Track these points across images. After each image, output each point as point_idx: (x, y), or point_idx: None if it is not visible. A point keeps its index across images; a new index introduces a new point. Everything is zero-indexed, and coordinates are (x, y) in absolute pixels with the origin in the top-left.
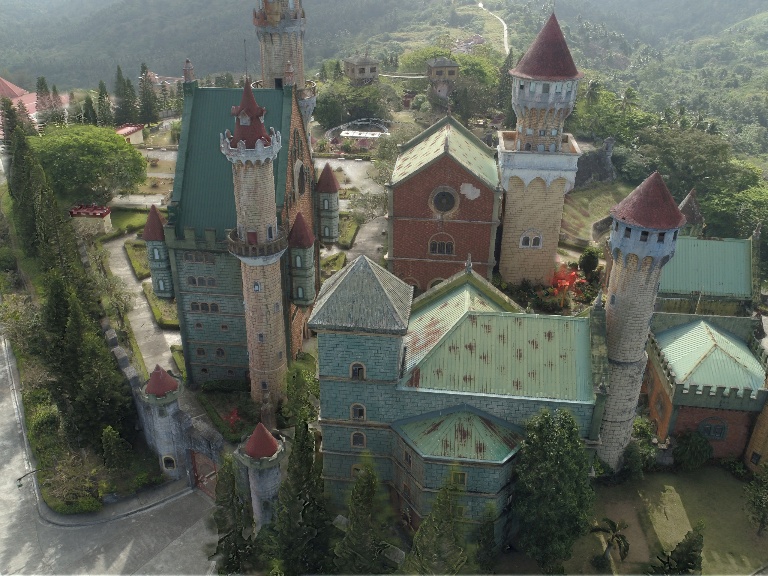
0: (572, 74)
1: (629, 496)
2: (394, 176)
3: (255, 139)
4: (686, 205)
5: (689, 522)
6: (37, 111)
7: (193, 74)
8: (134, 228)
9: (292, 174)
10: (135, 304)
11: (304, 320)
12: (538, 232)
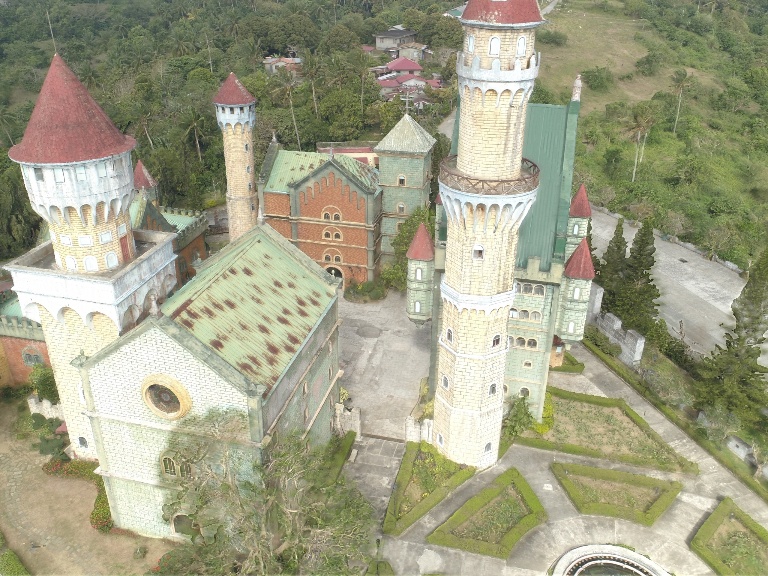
0: None
1: None
2: (312, 326)
3: None
4: None
5: None
6: None
7: (574, 92)
8: None
9: None
10: (656, 389)
11: None
12: None
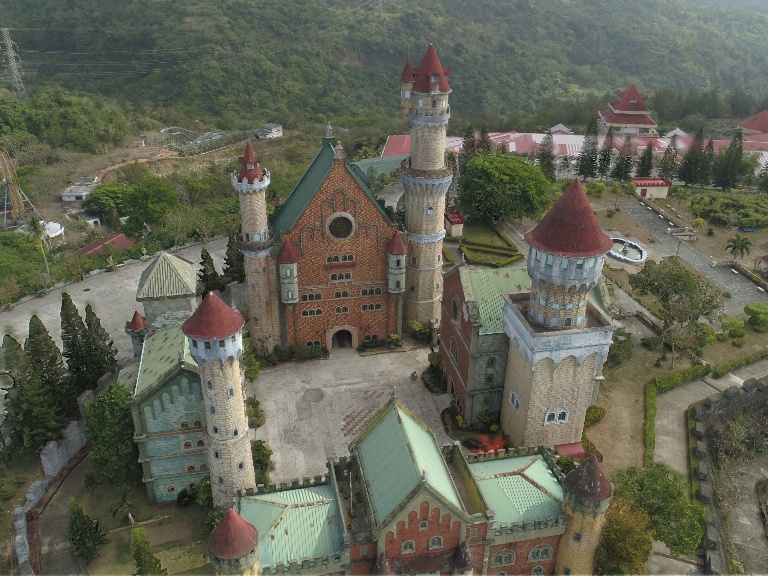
0: (557, 248)
1: (197, 534)
2: None
3: (241, 176)
4: (580, 465)
5: (172, 573)
6: (583, 142)
7: None
8: (467, 242)
9: (322, 218)
10: None
11: (339, 328)
12: (518, 396)
